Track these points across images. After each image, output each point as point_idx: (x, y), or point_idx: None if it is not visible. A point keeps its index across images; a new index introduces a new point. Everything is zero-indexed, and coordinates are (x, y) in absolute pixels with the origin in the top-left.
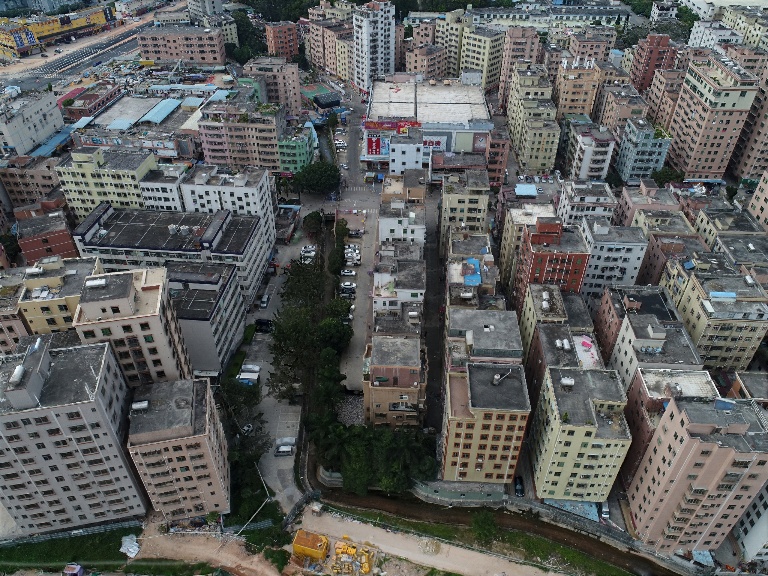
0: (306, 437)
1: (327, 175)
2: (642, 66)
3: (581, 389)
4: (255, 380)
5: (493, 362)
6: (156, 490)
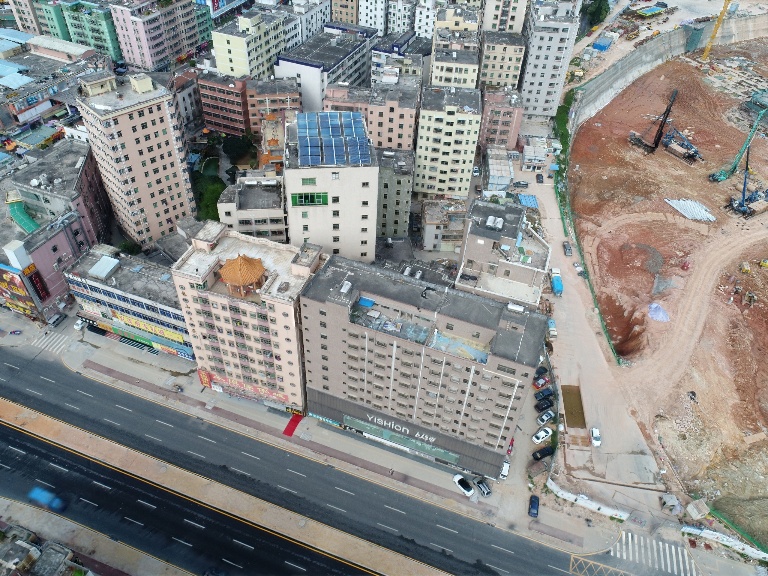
0: None
1: None
2: None
3: None
4: None
5: None
6: None
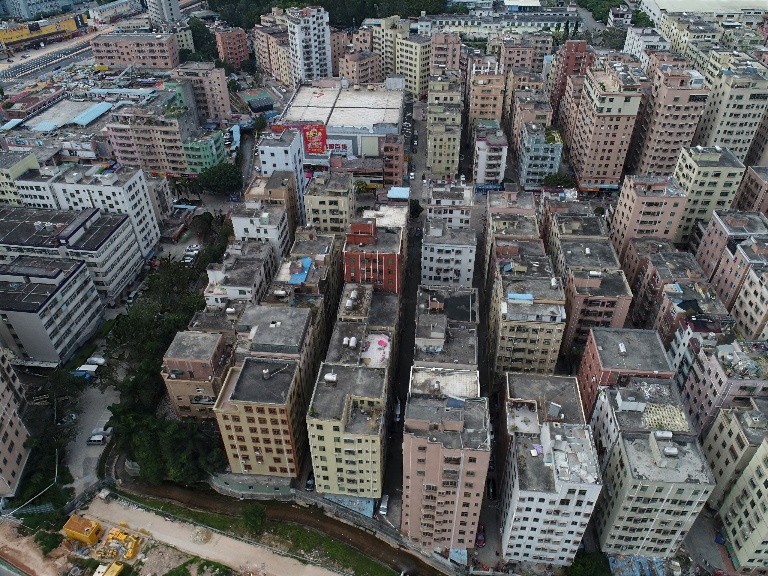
0: None
1: (226, 177)
2: (560, 72)
3: (345, 385)
4: (93, 372)
5: (274, 357)
6: None
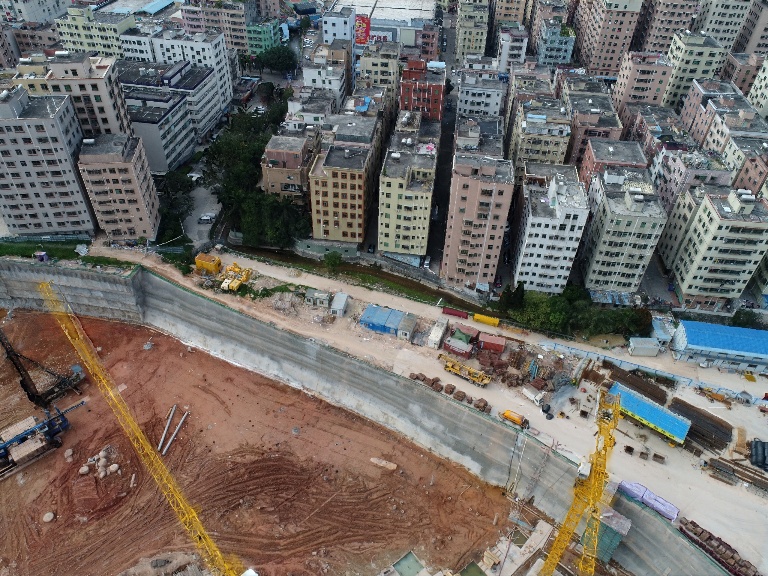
0: None
1: (284, 56)
2: None
3: (406, 162)
4: None
5: None
6: (100, 208)
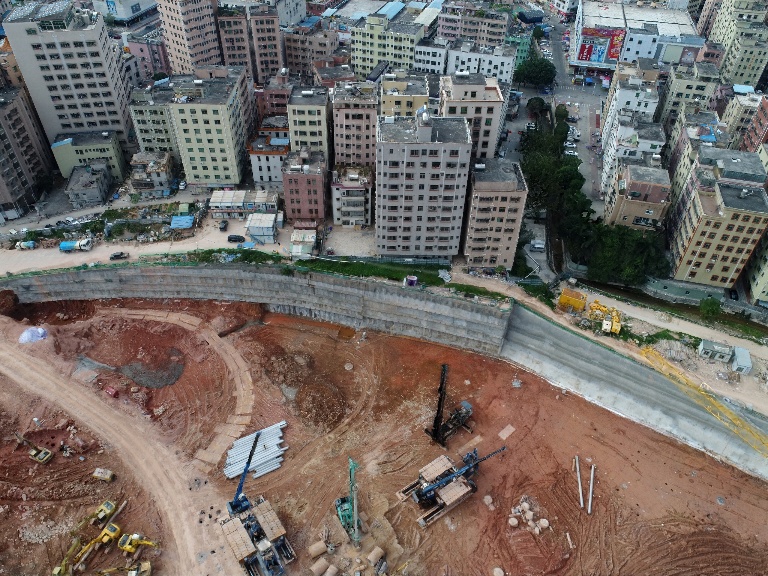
0: (550, 245)
1: (547, 69)
2: None
3: None
4: None
5: None
6: (473, 235)
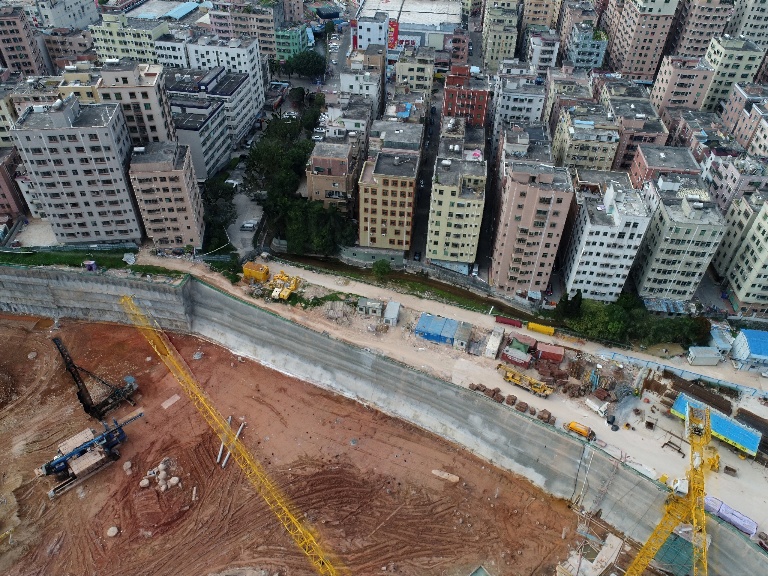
0: (266, 225)
1: (314, 61)
2: None
3: (457, 170)
4: None
5: None
6: (148, 217)
